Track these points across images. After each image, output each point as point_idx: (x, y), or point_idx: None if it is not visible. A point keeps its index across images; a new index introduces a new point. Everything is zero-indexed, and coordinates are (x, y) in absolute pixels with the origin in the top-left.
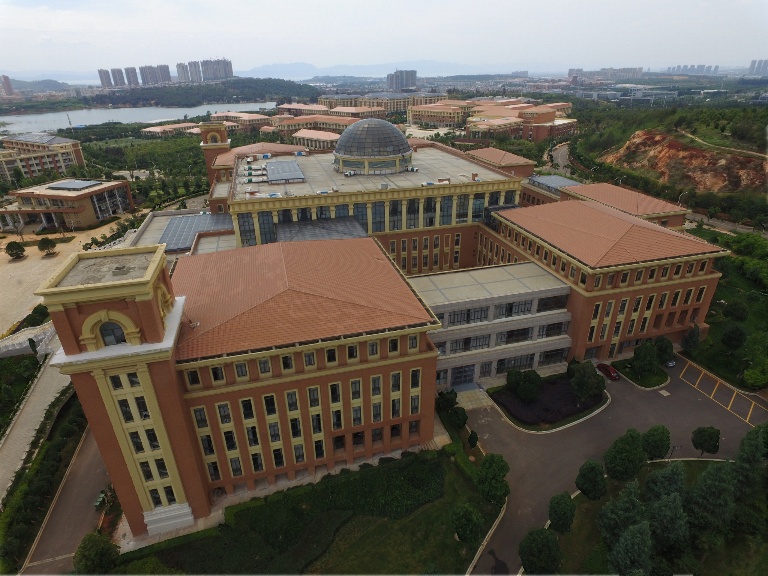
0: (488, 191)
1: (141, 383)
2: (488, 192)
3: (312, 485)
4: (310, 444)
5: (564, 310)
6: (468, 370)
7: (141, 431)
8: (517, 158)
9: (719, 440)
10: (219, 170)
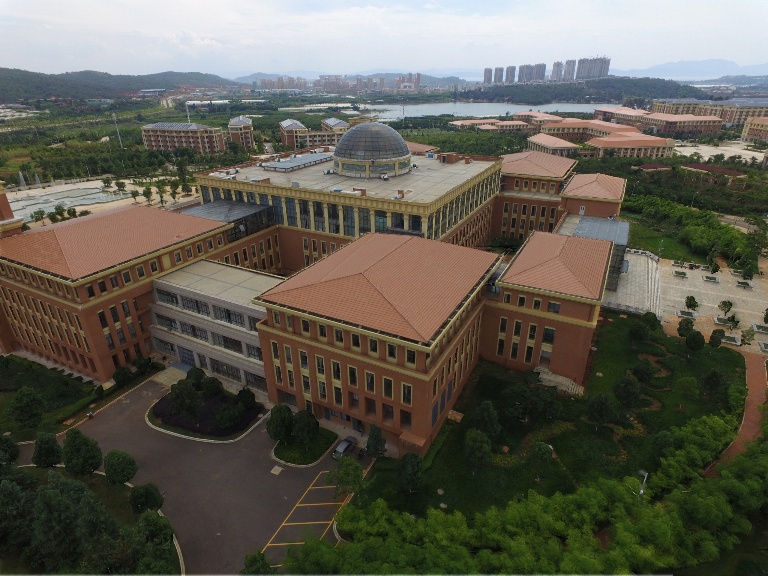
0: (389, 210)
1: None
2: (389, 211)
3: None
4: (45, 339)
5: None
6: (189, 354)
7: None
8: (599, 191)
9: (212, 531)
10: None
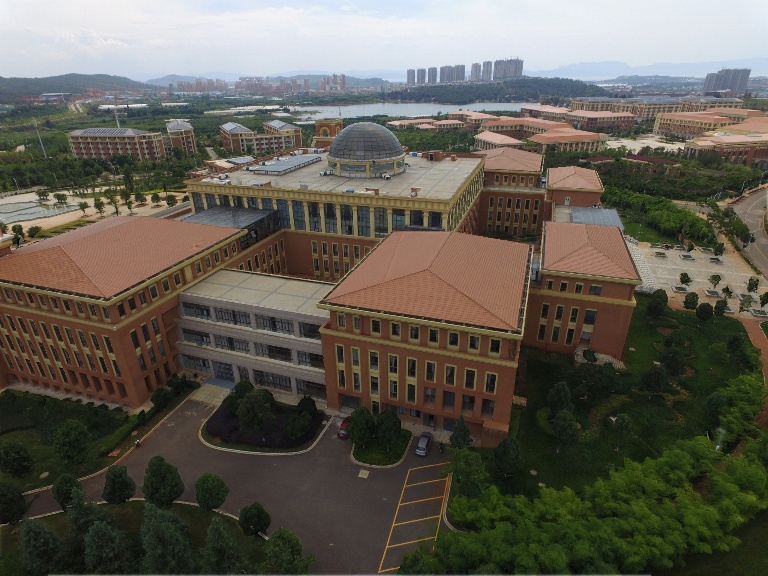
0: (408, 208)
1: None
2: (408, 209)
3: None
4: (55, 368)
5: None
6: (227, 368)
7: None
8: (581, 182)
9: (323, 542)
10: None
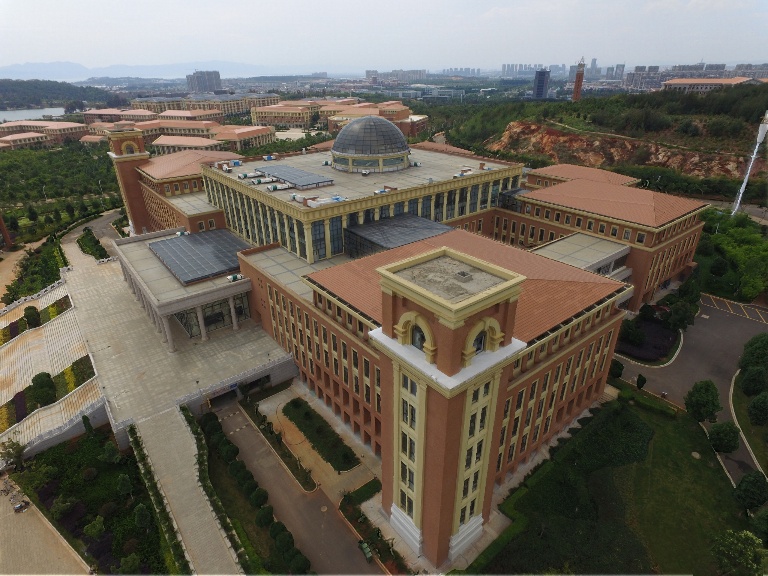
0: (502, 178)
1: (490, 391)
2: (502, 178)
3: (549, 460)
4: None
5: (624, 267)
6: None
7: (475, 445)
8: (457, 150)
9: None
10: (162, 184)
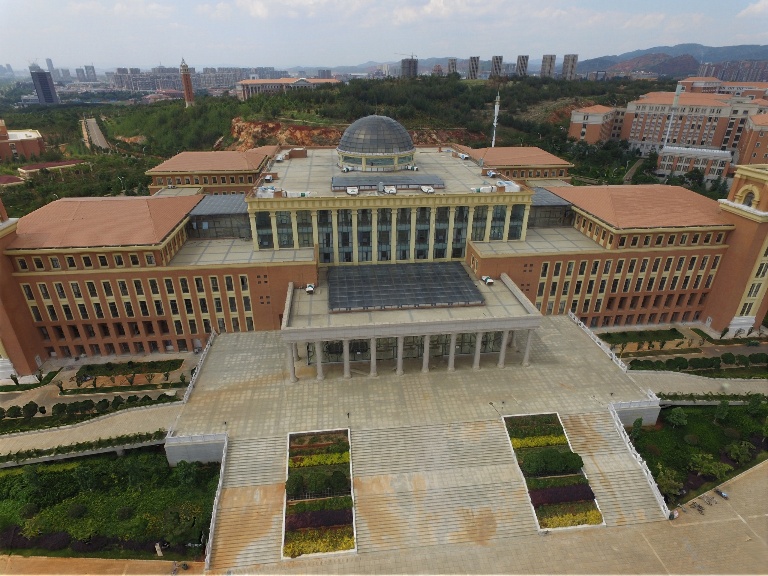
0: None
1: None
2: None
3: None
4: None
5: None
6: None
7: None
8: None
9: None
10: (159, 250)
